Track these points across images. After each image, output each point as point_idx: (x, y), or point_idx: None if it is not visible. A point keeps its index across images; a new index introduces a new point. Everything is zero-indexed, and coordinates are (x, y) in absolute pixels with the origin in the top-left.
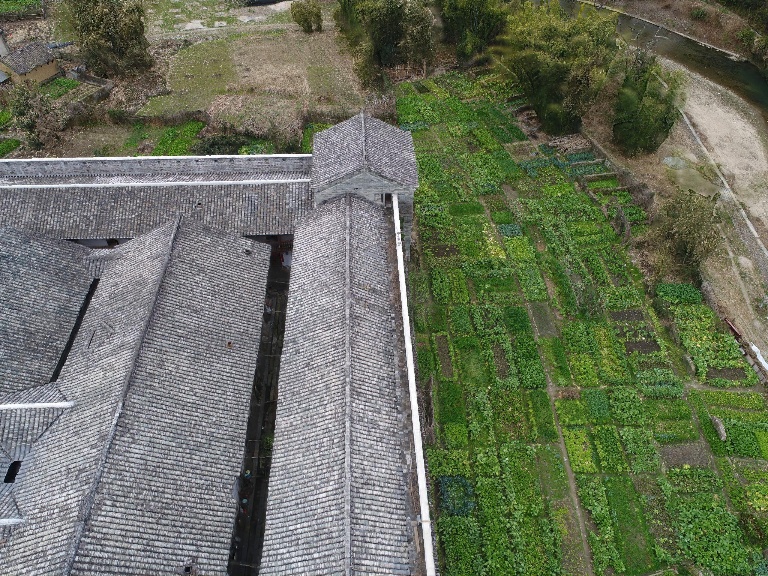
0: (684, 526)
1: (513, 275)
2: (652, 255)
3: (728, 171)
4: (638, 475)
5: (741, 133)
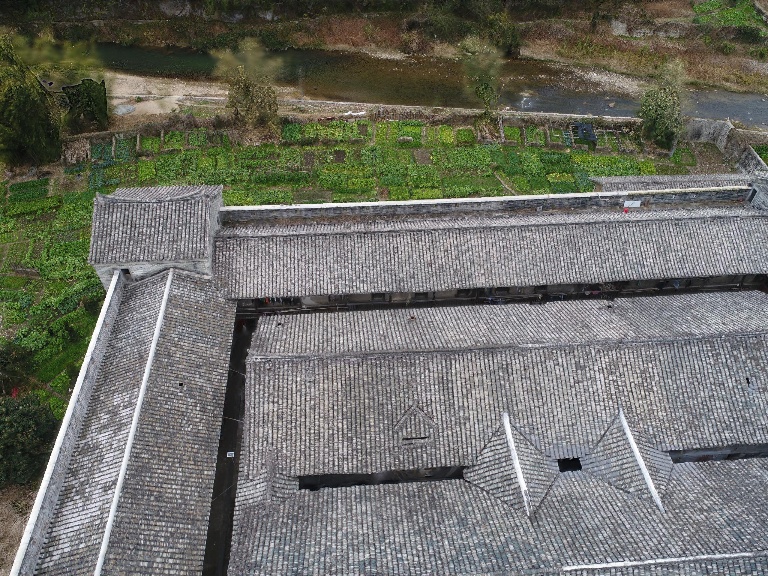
0: None
1: None
2: (250, 136)
3: (143, 91)
4: (439, 176)
5: (86, 77)
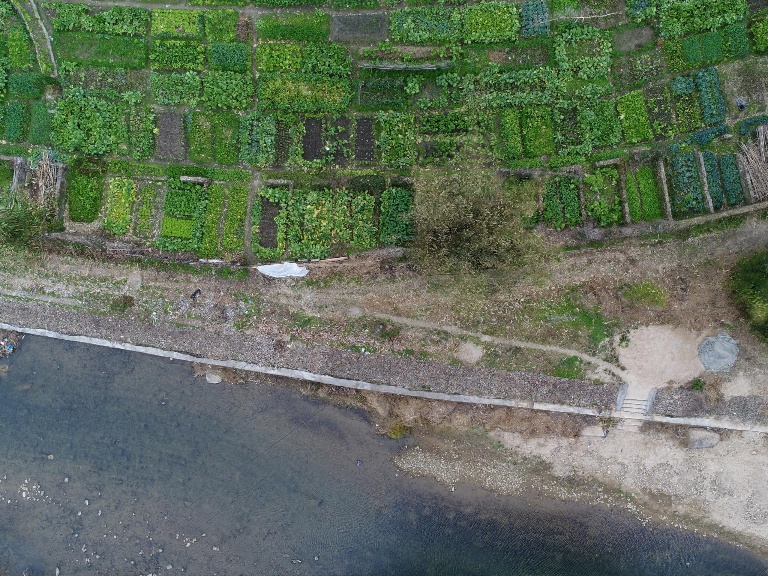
0: (94, 101)
1: (439, 4)
2: None
3: (698, 437)
4: None
5: None
